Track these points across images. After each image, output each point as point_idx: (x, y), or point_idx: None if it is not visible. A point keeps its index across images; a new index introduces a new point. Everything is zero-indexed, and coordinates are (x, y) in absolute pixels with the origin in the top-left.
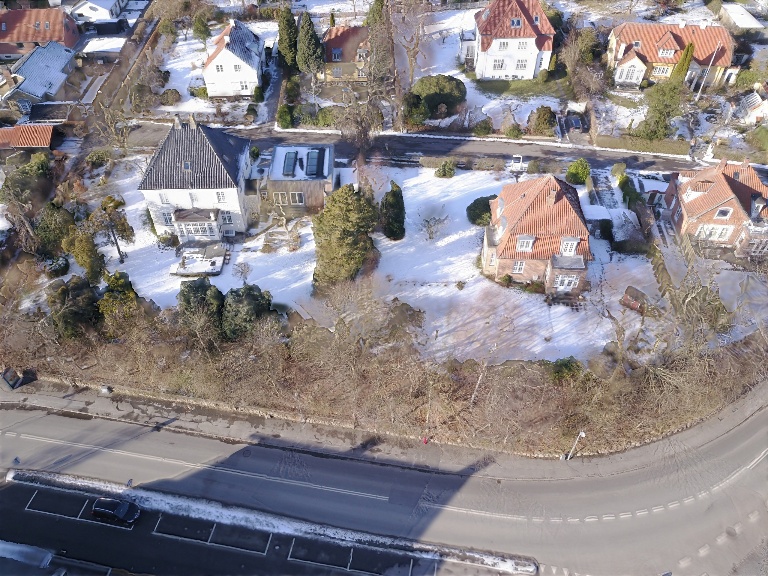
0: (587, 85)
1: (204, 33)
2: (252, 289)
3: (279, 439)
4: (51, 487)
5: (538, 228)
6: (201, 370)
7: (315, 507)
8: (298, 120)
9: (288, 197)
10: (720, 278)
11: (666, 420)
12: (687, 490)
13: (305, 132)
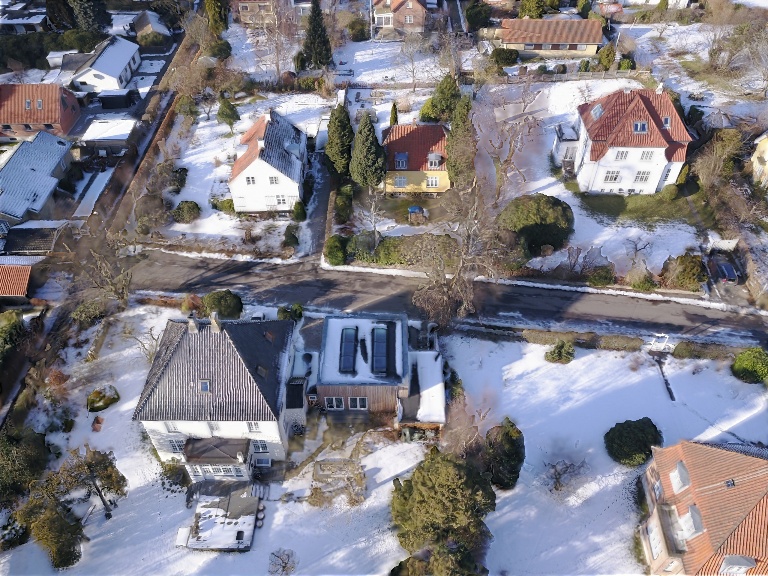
0: None
1: (231, 117)
2: None
3: None
4: None
5: (762, 547)
6: None
7: None
8: (352, 255)
9: (346, 402)
10: None
11: None
12: None
13: (361, 272)
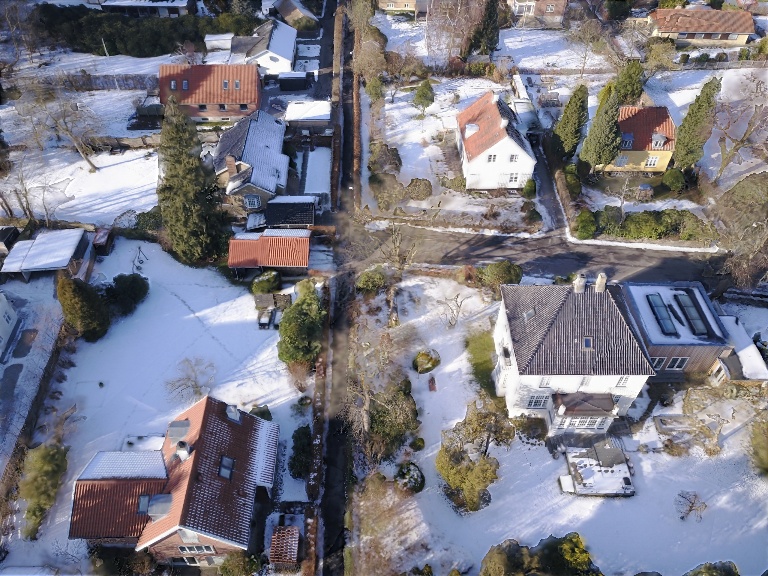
0: None
1: (429, 99)
2: None
3: None
4: None
5: None
6: None
7: None
8: (600, 229)
9: (666, 362)
10: None
11: None
12: None
13: (610, 245)
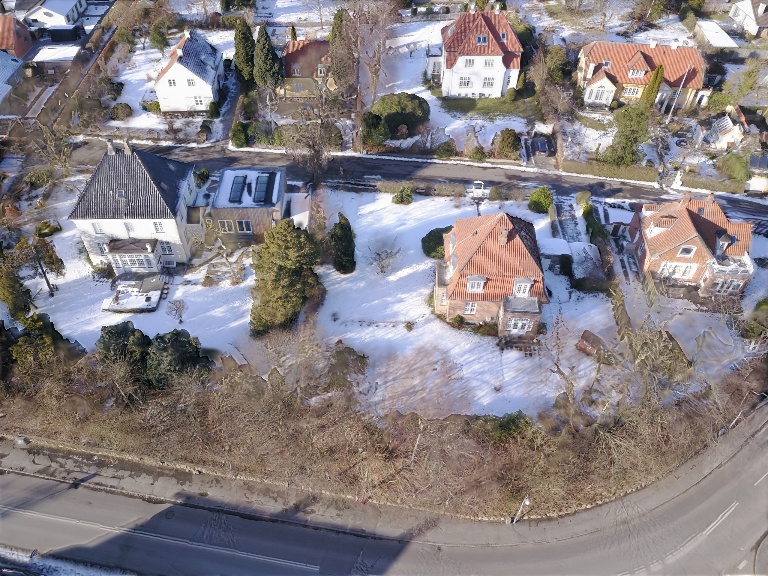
0: (555, 105)
1: (161, 43)
2: (180, 334)
3: (206, 498)
4: None
5: (490, 269)
6: (126, 420)
7: None
8: (253, 139)
9: (235, 225)
10: (682, 319)
11: (619, 479)
12: (638, 559)
13: (260, 151)
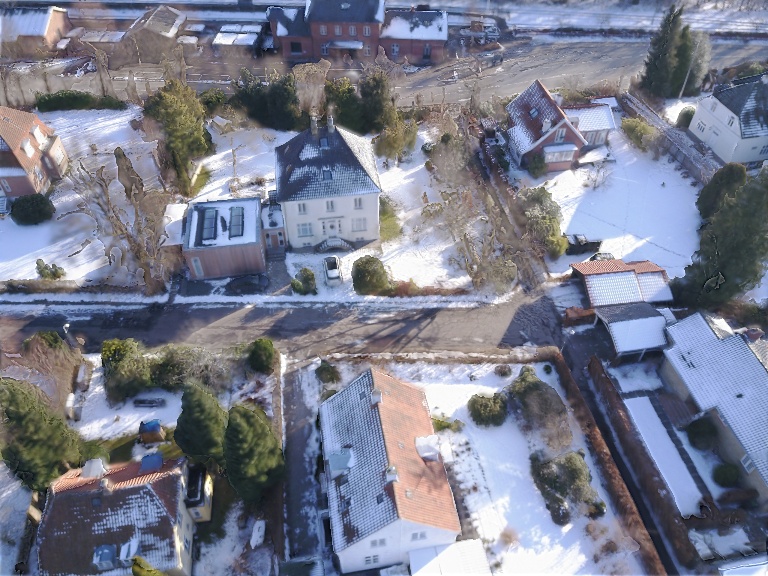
0: None
1: None
2: (245, 88)
3: None
4: (356, 84)
5: None
6: None
7: (217, 87)
8: None
9: None
10: None
11: None
12: None
13: None
